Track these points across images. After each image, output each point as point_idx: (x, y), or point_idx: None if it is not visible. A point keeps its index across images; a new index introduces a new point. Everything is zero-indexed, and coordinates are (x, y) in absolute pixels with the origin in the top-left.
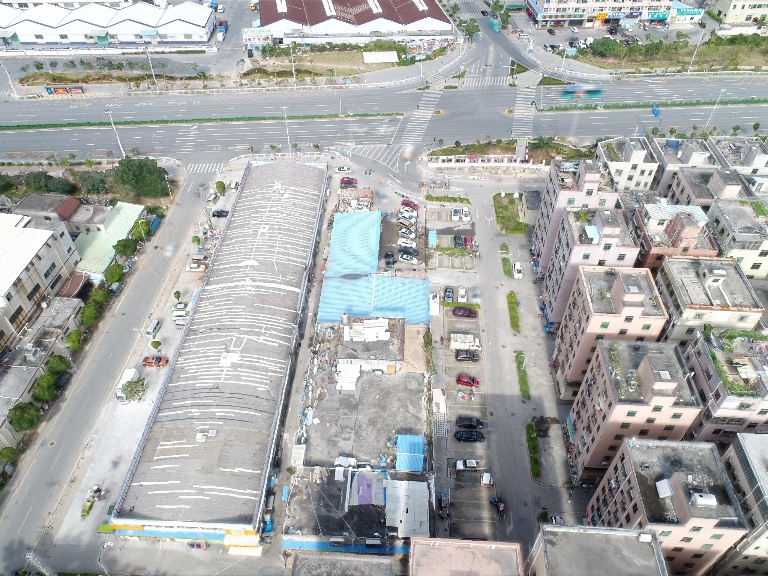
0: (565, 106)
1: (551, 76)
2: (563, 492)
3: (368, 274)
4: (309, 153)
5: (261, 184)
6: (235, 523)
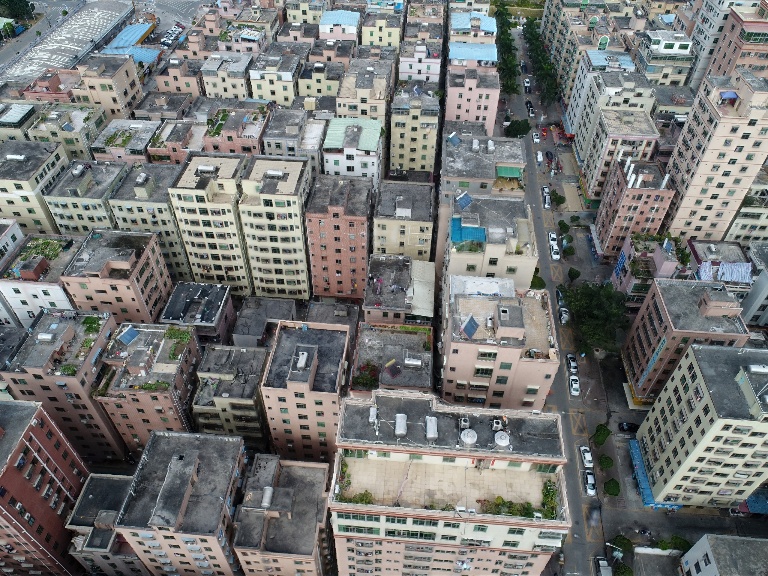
0: None
1: None
2: None
3: (128, 46)
4: None
5: (87, 9)
6: None
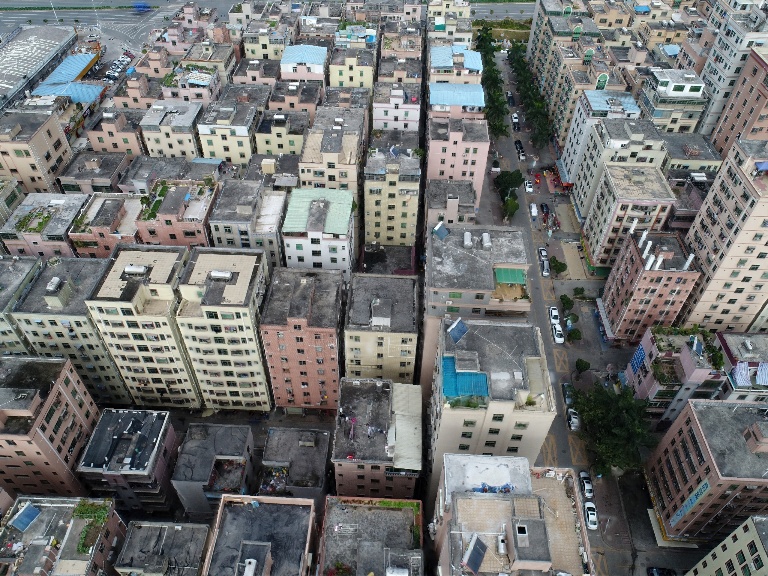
0: None
1: None
2: None
3: (66, 82)
4: (75, 27)
5: (21, 38)
6: None
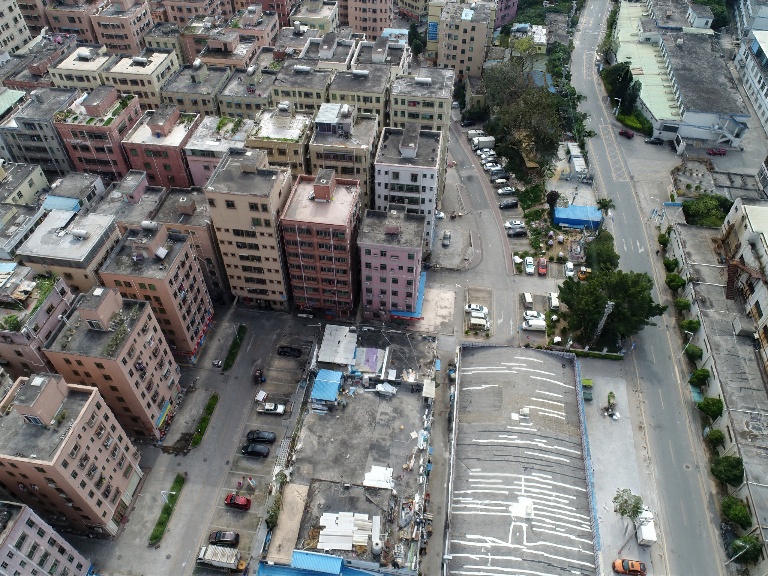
0: None
1: None
2: (199, 385)
3: None
4: None
5: None
6: (476, 349)
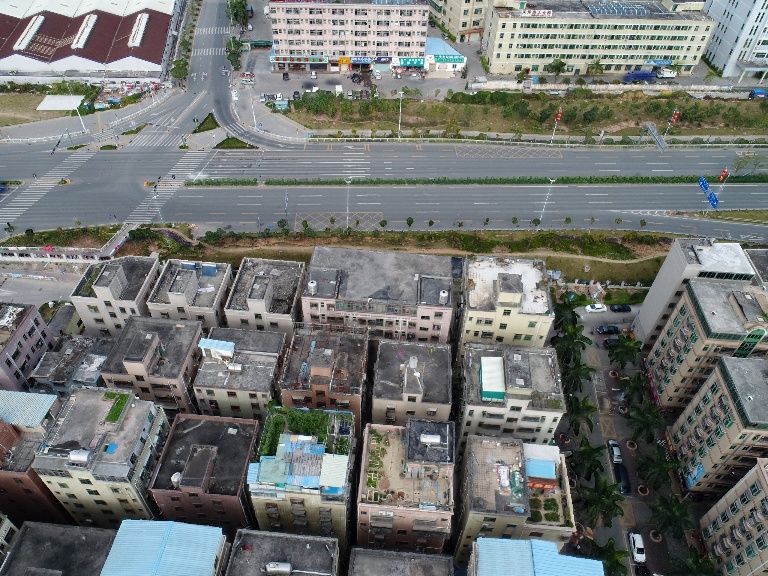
0: (216, 180)
1: (240, 136)
2: None
3: None
4: None
5: None
6: None
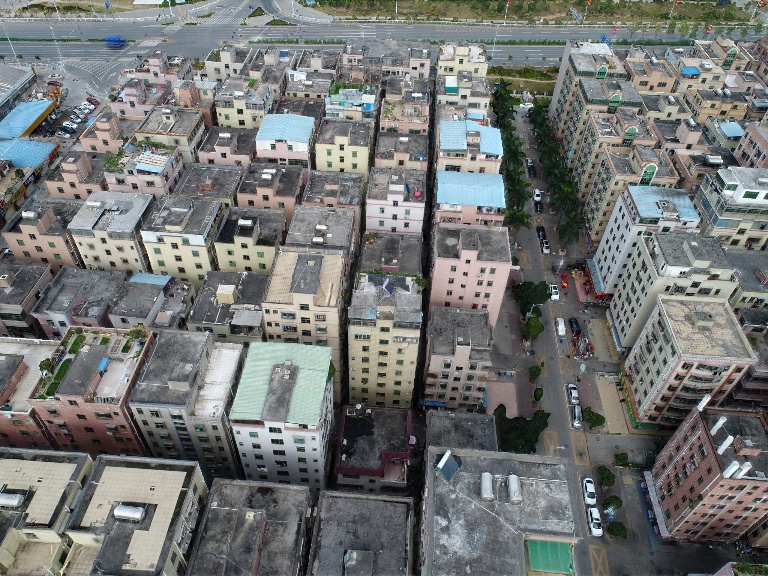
0: (270, 39)
1: (282, 19)
2: None
3: (11, 138)
4: (36, 64)
5: None
6: None
